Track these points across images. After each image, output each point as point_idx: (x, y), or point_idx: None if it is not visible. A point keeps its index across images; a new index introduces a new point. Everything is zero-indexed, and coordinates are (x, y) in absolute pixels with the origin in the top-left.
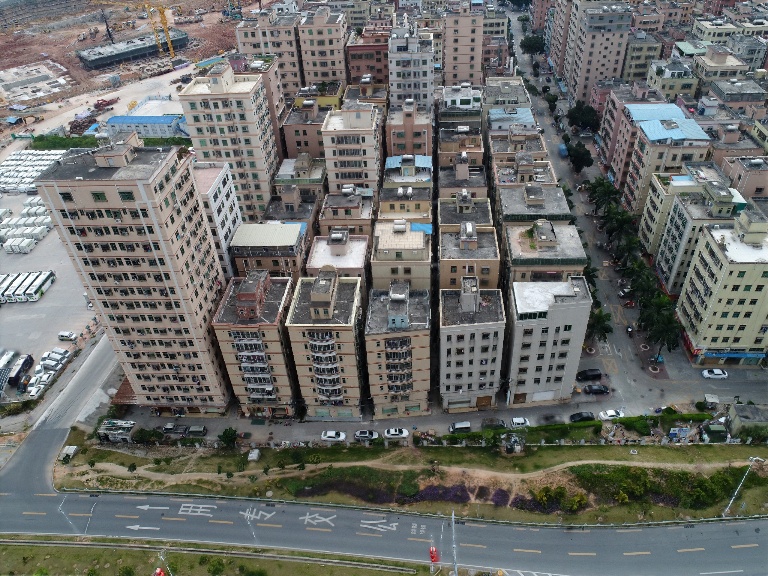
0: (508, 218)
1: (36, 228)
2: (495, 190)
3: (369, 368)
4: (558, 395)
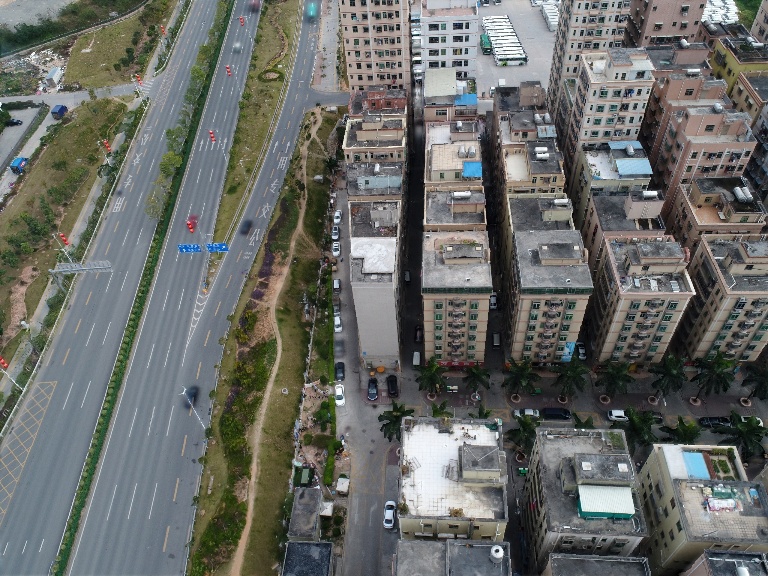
0: None
1: None
2: None
3: None
4: None
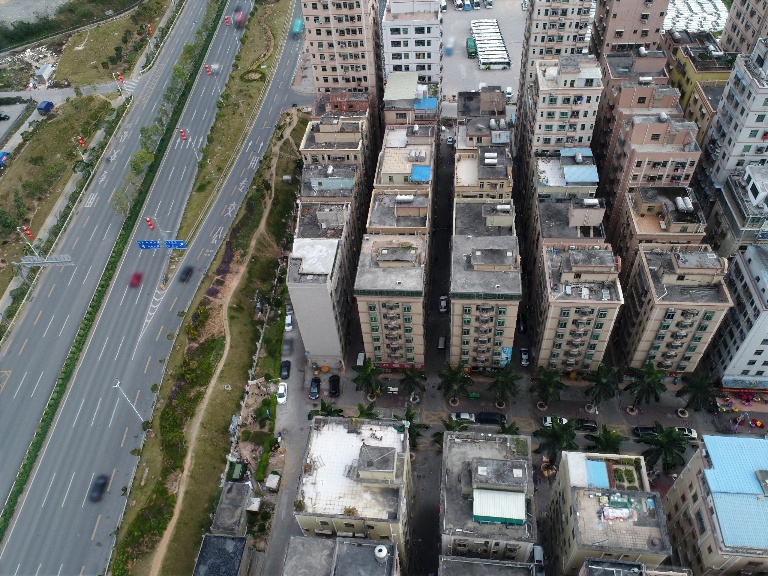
0: None
1: None
2: None
3: None
4: None
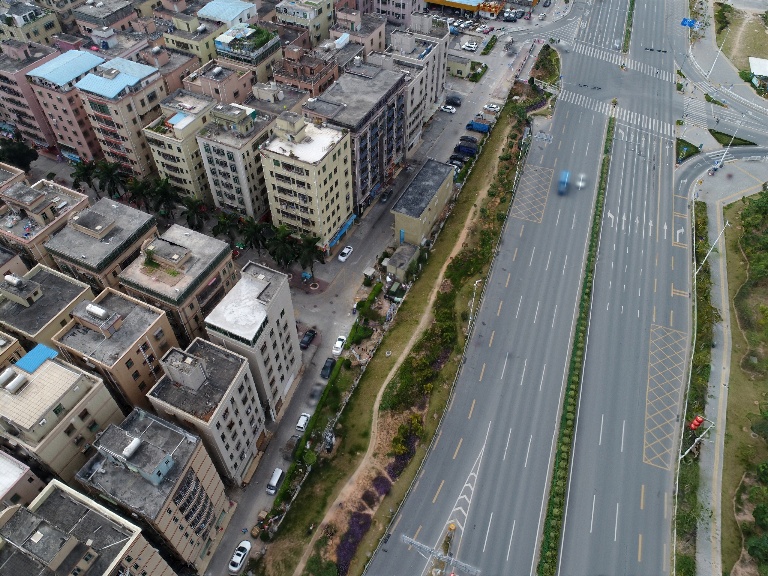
0: (101, 267)
1: None
2: (24, 251)
3: (173, 543)
4: (296, 372)
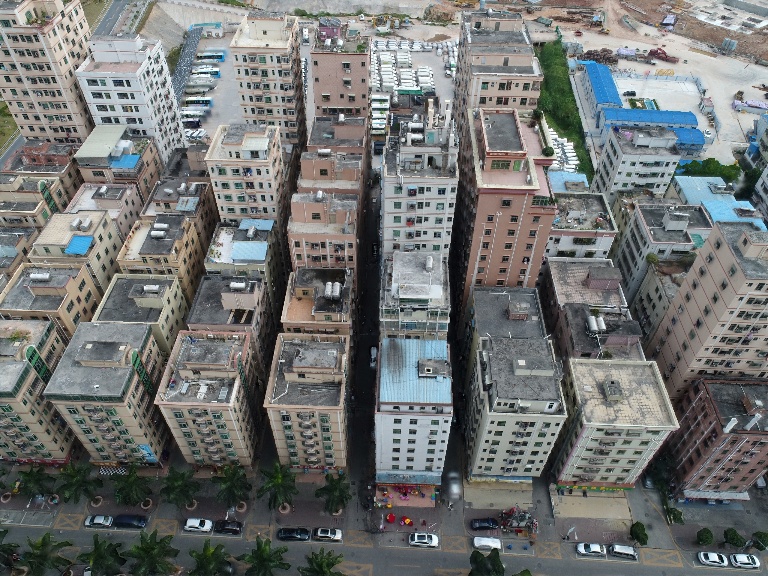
0: None
1: (374, 82)
2: None
3: None
4: None
